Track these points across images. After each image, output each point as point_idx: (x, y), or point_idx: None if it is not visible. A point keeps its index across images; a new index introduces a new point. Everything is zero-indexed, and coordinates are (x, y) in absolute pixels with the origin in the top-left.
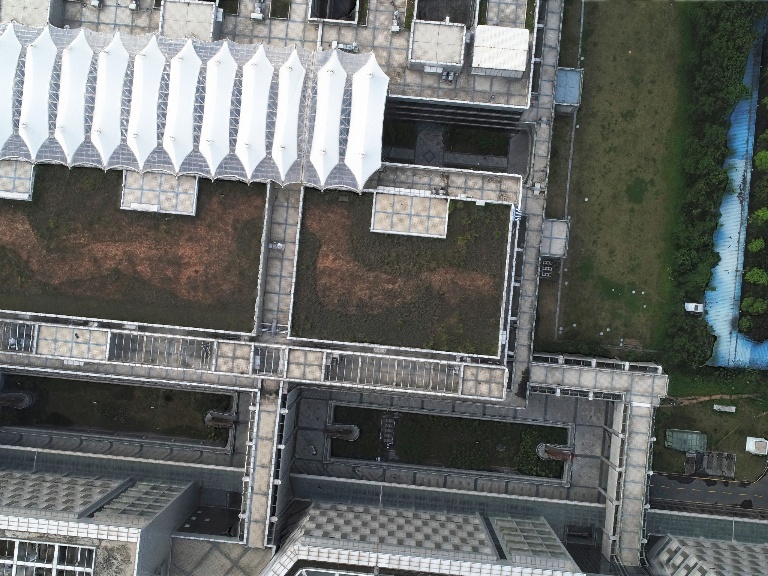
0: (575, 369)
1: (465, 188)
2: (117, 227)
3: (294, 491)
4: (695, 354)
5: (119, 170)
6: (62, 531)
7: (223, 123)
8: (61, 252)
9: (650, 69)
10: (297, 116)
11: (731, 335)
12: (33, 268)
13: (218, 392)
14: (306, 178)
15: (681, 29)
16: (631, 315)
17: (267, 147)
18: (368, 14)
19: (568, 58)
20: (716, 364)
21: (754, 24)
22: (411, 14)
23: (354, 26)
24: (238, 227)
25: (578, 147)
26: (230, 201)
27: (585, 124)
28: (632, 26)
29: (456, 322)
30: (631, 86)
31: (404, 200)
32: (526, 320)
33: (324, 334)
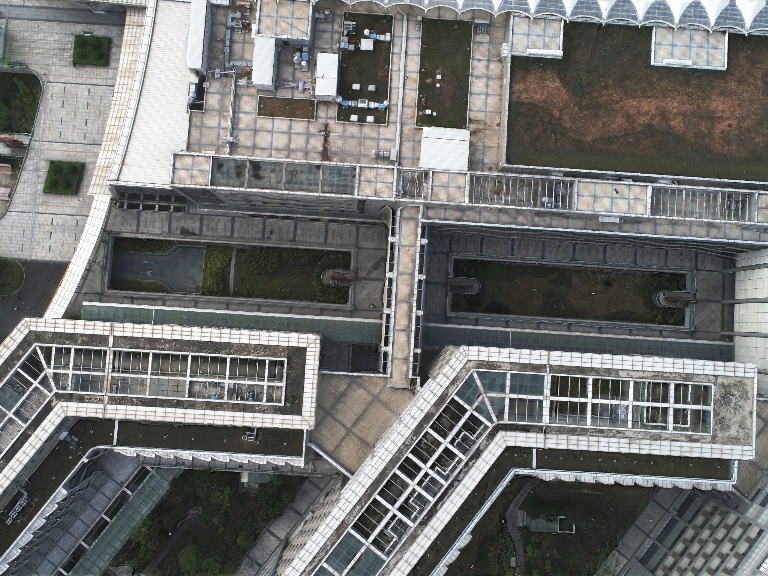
0: None
1: None
2: (648, 83)
3: None
4: None
5: (649, 26)
6: (678, 369)
7: None
8: (593, 109)
9: None
10: None
11: None
12: (566, 125)
13: (674, 271)
14: None
15: None
16: None
17: None
18: None
19: None
20: None
21: None
22: None
23: None
24: (767, 81)
25: None
26: (757, 56)
27: None
28: None
29: None
30: None
31: None
32: None
33: None
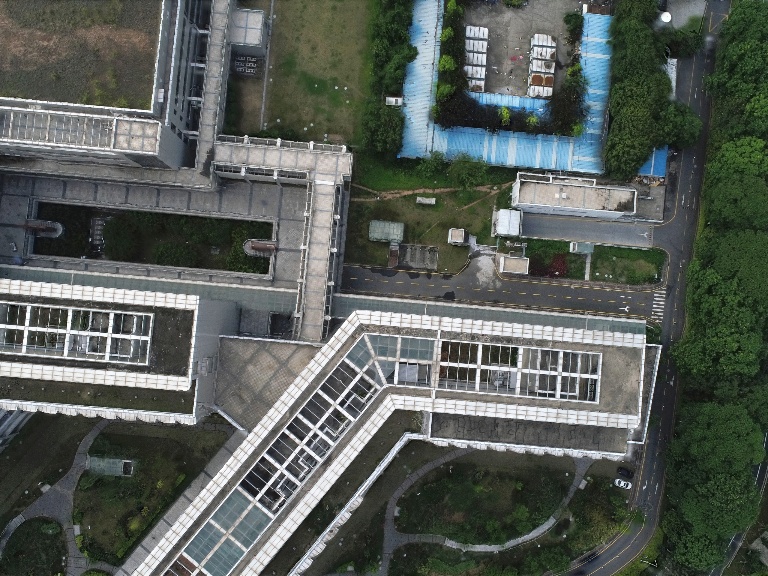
0: (259, 148)
1: None
2: None
3: None
4: (378, 133)
5: None
6: None
7: None
8: None
9: None
10: None
11: (428, 126)
12: None
13: None
14: None
15: None
16: (334, 110)
17: None
18: None
19: None
20: (414, 155)
21: None
22: None
23: None
24: None
25: None
26: None
27: None
28: None
29: (111, 78)
30: None
31: None
32: (211, 100)
33: None
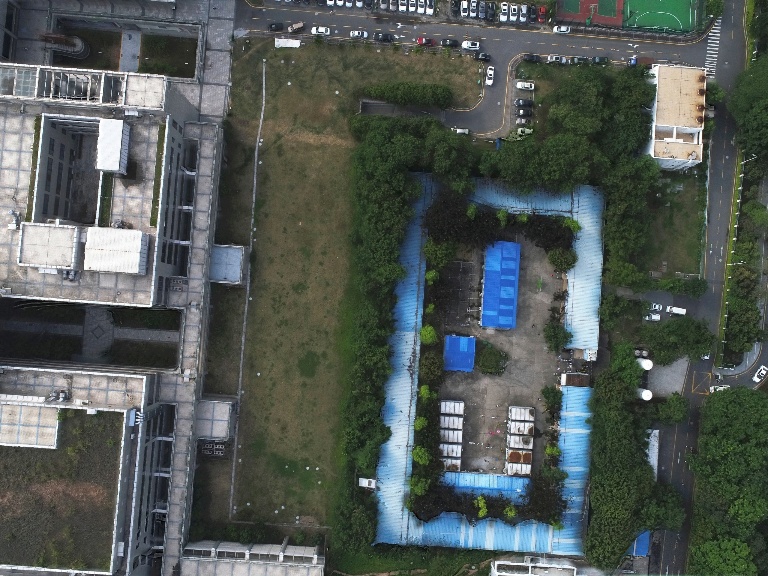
0: (227, 562)
1: (89, 389)
2: None
3: None
4: (350, 542)
5: None
6: None
7: None
8: None
9: (321, 240)
10: None
11: (403, 512)
12: None
13: None
14: None
15: (351, 200)
16: (305, 492)
17: None
18: None
19: (240, 229)
20: (389, 542)
21: (407, 203)
22: (31, 210)
23: None
24: None
25: (251, 320)
26: None
27: (257, 296)
28: (302, 197)
29: (68, 536)
30: (302, 258)
31: (12, 410)
32: (176, 512)
33: None
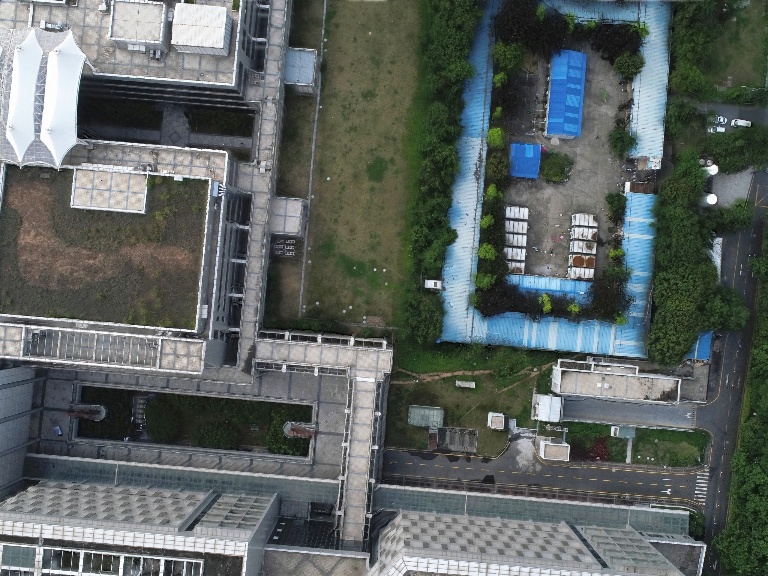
0: (300, 345)
1: (174, 165)
2: None
3: (26, 470)
4: (418, 329)
5: None
6: None
7: None
8: None
9: (390, 50)
10: None
11: (468, 311)
12: None
13: None
14: (4, 155)
15: (420, 10)
16: (373, 293)
17: None
18: None
19: (311, 40)
20: (453, 340)
21: (477, 4)
22: None
23: (64, 6)
24: None
25: (321, 127)
26: None
27: (327, 104)
28: (372, 8)
29: (156, 296)
30: (371, 67)
31: (104, 176)
32: (252, 297)
33: (25, 310)
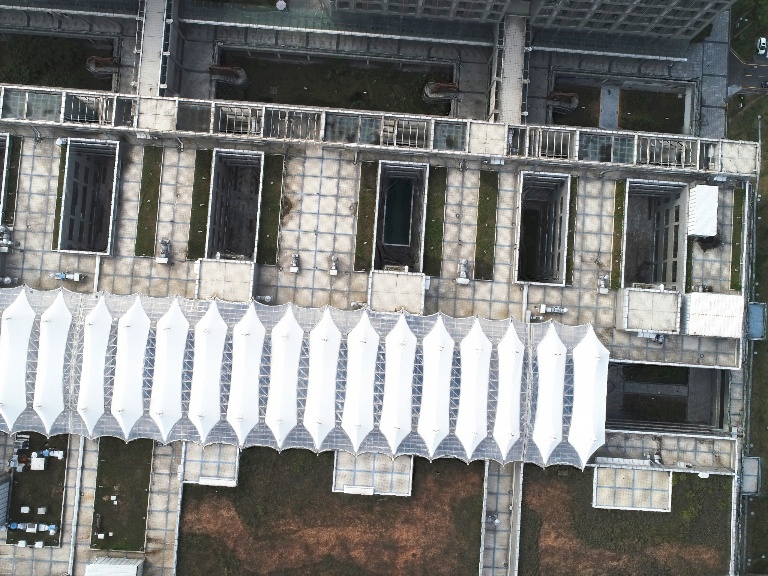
0: None
1: (678, 450)
2: (329, 511)
3: None
4: None
5: (330, 451)
6: None
7: (444, 405)
8: (270, 539)
9: None
10: (519, 395)
11: None
12: (240, 557)
13: None
14: (527, 456)
15: None
16: None
17: (488, 427)
18: (573, 274)
19: None
20: None
21: None
22: (618, 274)
23: (560, 287)
24: (455, 506)
25: (757, 374)
26: (446, 479)
27: (763, 351)
28: None
29: None
30: None
31: (626, 473)
32: None
33: None
